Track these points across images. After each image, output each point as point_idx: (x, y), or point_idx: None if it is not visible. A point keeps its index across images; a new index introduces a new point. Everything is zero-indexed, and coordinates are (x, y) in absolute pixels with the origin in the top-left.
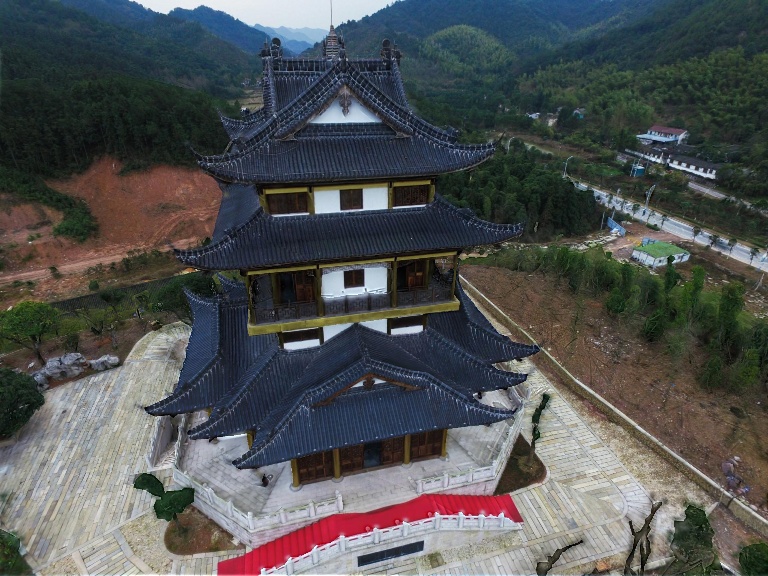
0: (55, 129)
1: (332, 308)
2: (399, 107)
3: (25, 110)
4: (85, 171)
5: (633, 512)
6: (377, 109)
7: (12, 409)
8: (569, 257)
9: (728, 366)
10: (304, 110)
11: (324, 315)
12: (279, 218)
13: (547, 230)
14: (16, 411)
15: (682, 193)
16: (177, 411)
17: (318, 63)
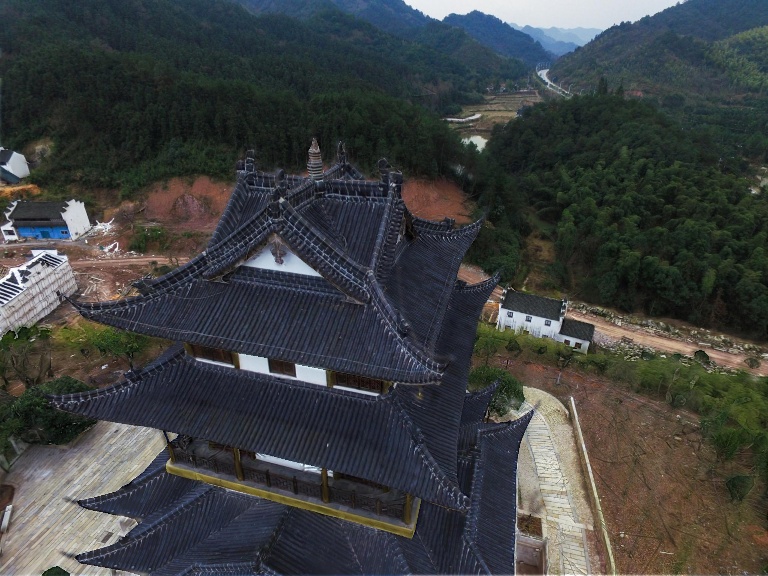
0: (289, 135)
1: (253, 476)
2: (353, 265)
3: (274, 117)
4: (302, 173)
5: None
6: (317, 265)
7: (65, 425)
8: None
9: None
10: (236, 251)
11: (244, 480)
12: (202, 363)
13: None
14: (68, 427)
15: None
16: (110, 511)
17: (298, 181)
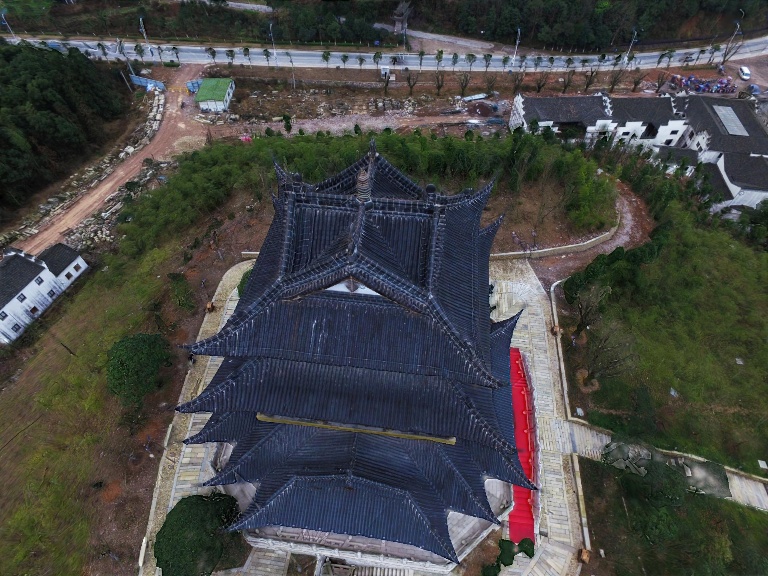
0: None
1: None
2: None
3: None
4: None
5: (524, 296)
6: None
7: None
8: (252, 162)
9: (448, 183)
10: None
11: None
12: None
13: (100, 126)
14: None
15: (140, 7)
16: (450, 540)
17: None
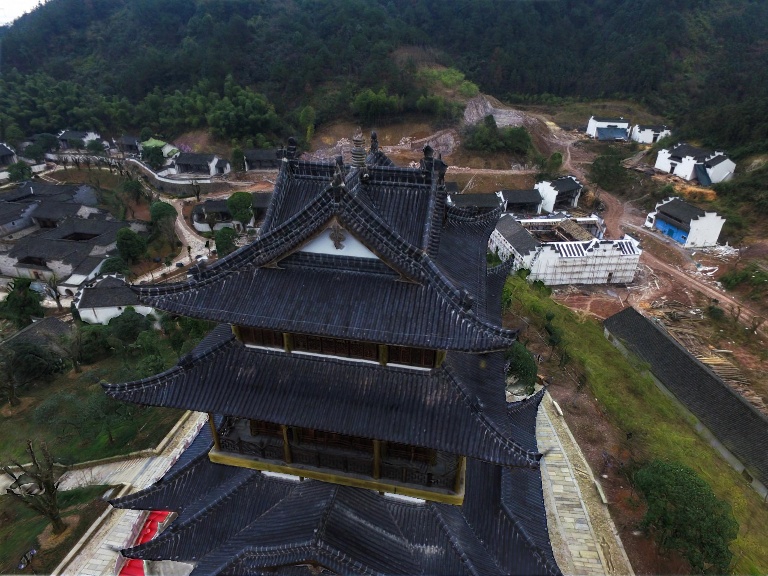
0: None
1: None
2: None
3: None
4: None
5: None
6: None
7: None
8: None
9: None
10: None
11: None
12: None
13: None
14: None
15: None
16: None
17: None
